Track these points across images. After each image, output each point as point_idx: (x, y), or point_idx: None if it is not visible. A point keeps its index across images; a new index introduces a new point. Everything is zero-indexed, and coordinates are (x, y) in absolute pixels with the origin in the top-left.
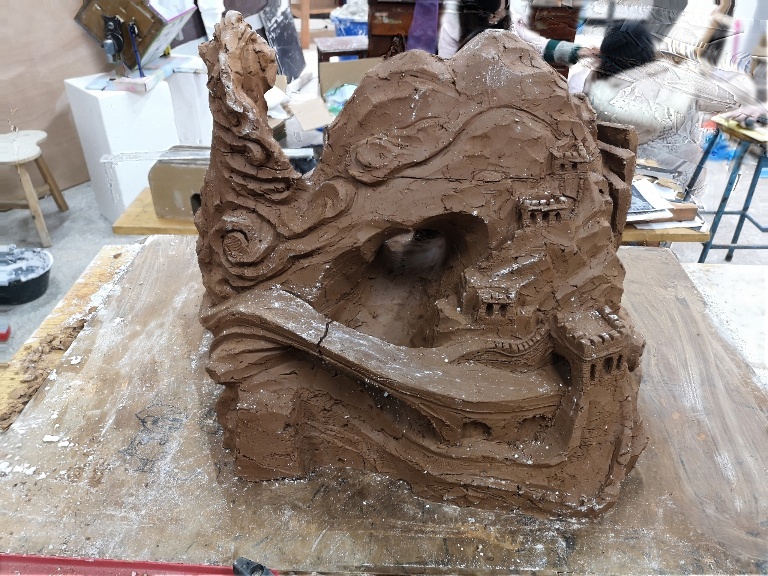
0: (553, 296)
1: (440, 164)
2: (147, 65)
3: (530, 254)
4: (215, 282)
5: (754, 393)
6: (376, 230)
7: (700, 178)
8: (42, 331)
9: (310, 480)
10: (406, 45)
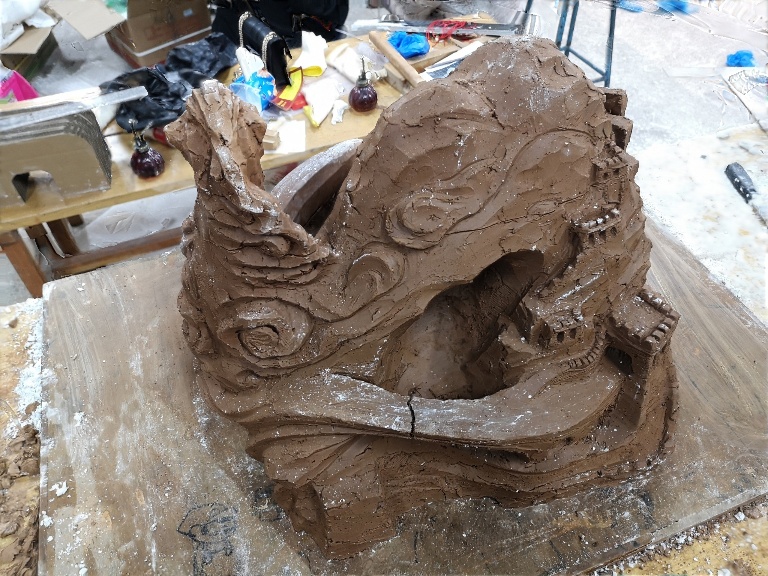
0: (607, 300)
1: (494, 209)
2: None
3: (591, 273)
4: (234, 375)
5: (715, 291)
6: (435, 292)
7: (536, 28)
8: None
9: (402, 532)
10: None
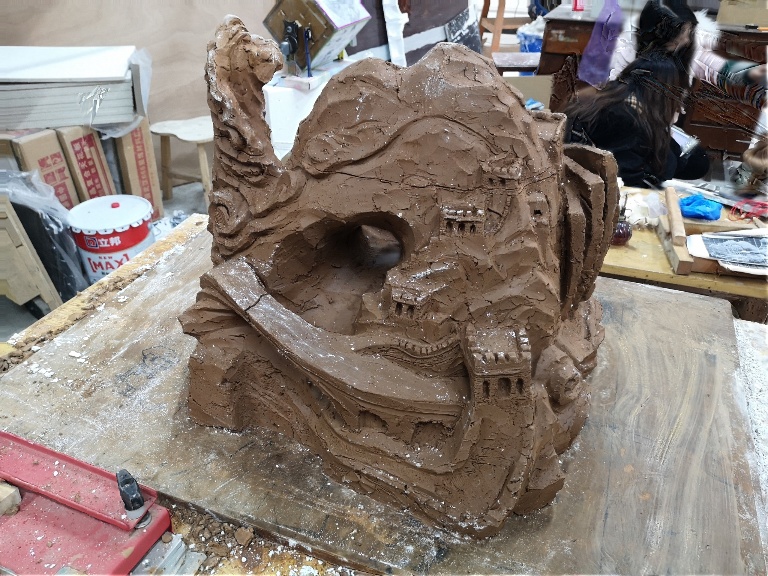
0: (467, 308)
1: (374, 165)
2: (319, 67)
3: (443, 261)
4: None
5: (738, 469)
6: (316, 219)
7: None
8: (116, 273)
9: (244, 435)
10: (579, 65)
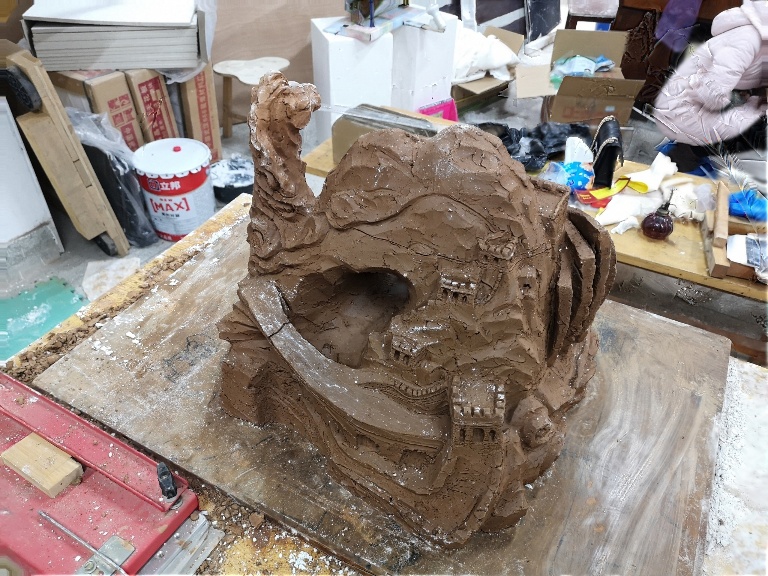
0: (455, 361)
1: (387, 228)
2: (383, 14)
3: (437, 322)
4: None
5: (690, 513)
6: (335, 264)
7: None
8: (170, 252)
9: (265, 429)
10: (658, 22)
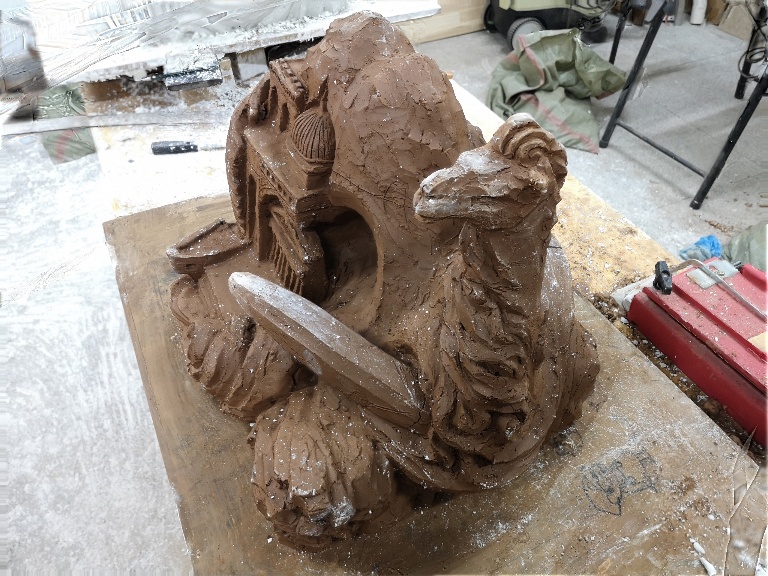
0: None
1: None
2: None
3: None
4: None
5: None
6: None
7: None
8: None
9: None
10: None
